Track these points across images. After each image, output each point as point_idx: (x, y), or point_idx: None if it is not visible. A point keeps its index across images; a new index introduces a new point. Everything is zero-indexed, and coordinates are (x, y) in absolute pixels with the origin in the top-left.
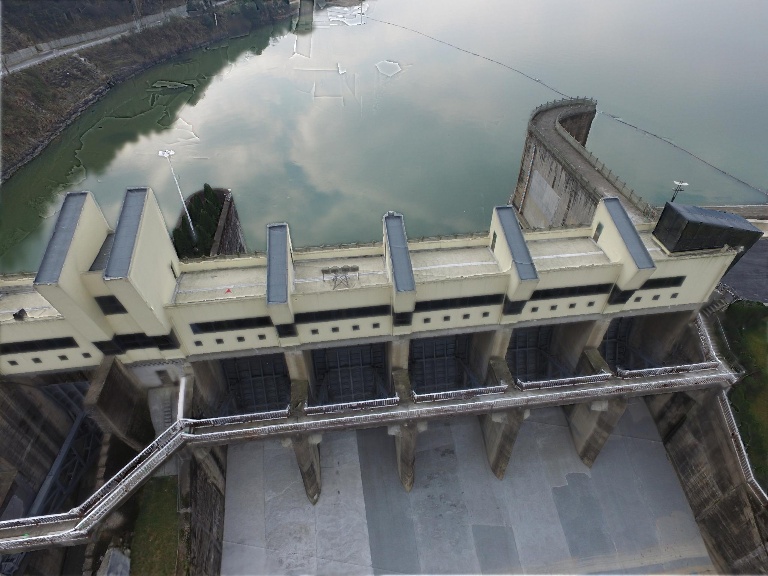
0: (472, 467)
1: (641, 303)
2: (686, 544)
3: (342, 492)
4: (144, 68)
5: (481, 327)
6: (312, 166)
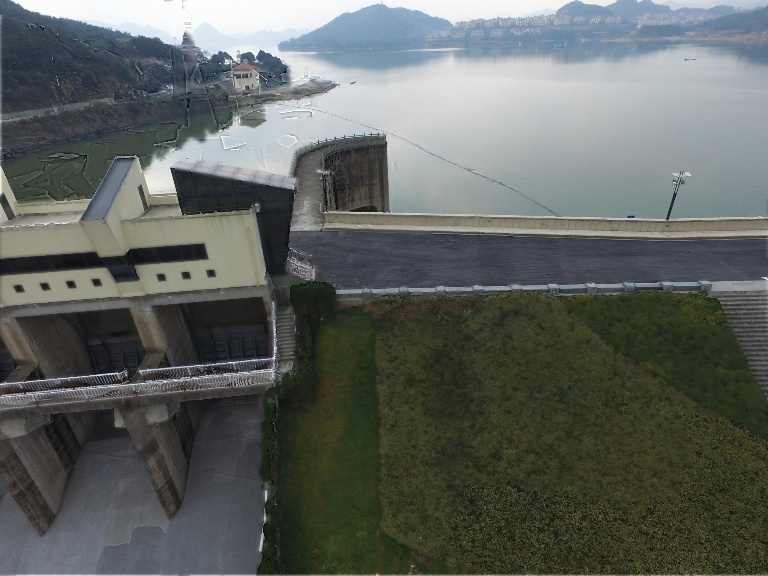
0: (14, 517)
1: (171, 283)
2: None
3: None
4: (53, 144)
5: None
6: None
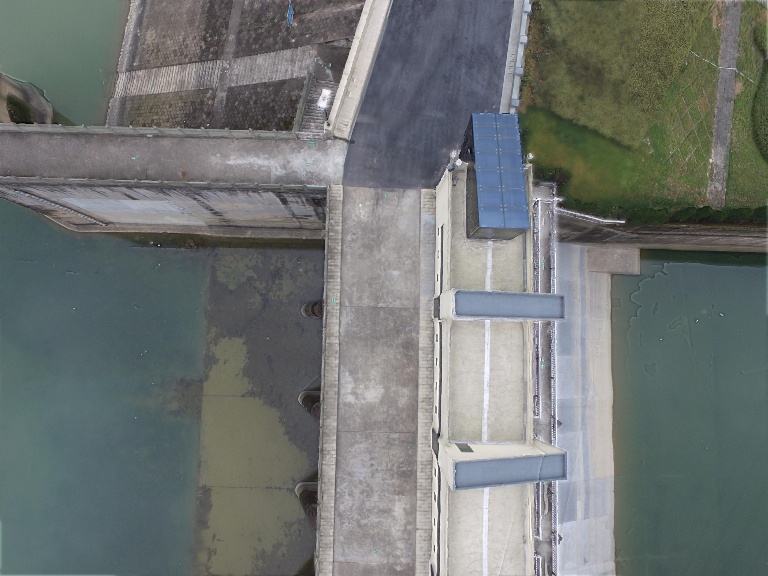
0: None
1: None
2: (572, 259)
3: None
4: None
5: None
6: None
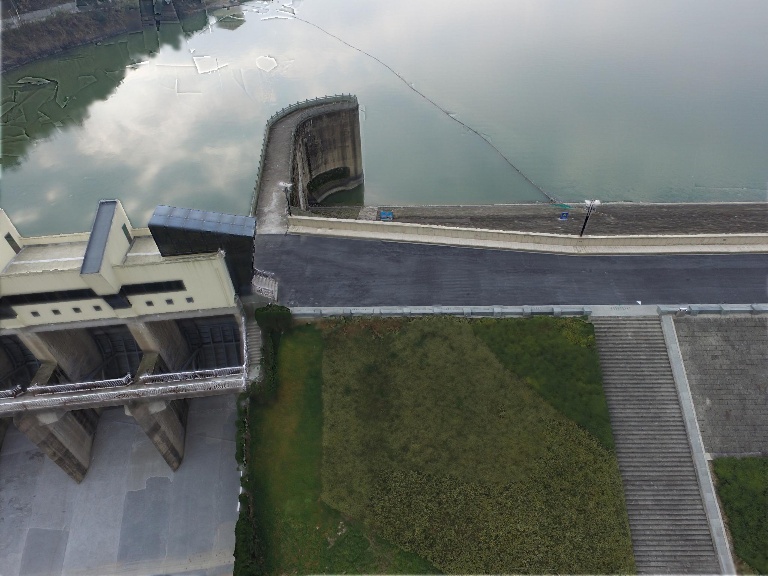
0: (55, 470)
1: (158, 307)
2: None
3: None
4: (19, 64)
5: None
6: (116, 164)
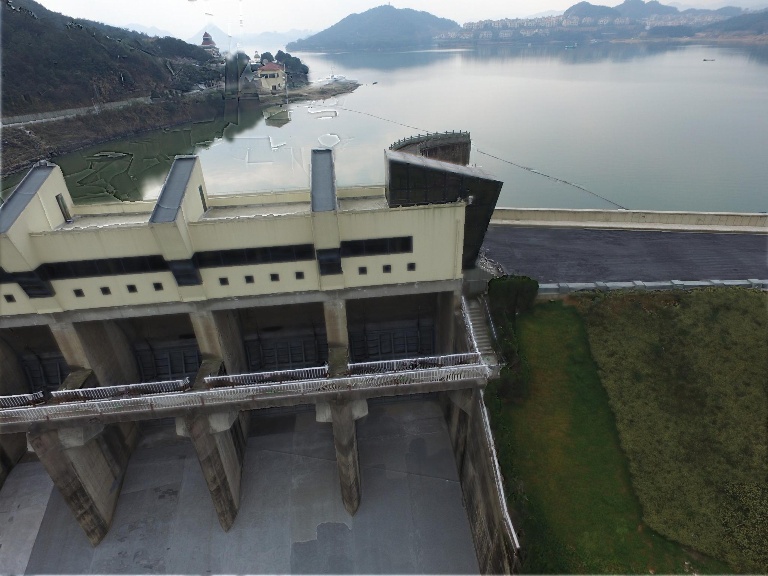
0: (194, 513)
1: (370, 277)
2: None
3: (4, 546)
4: (95, 143)
5: (165, 307)
6: None
